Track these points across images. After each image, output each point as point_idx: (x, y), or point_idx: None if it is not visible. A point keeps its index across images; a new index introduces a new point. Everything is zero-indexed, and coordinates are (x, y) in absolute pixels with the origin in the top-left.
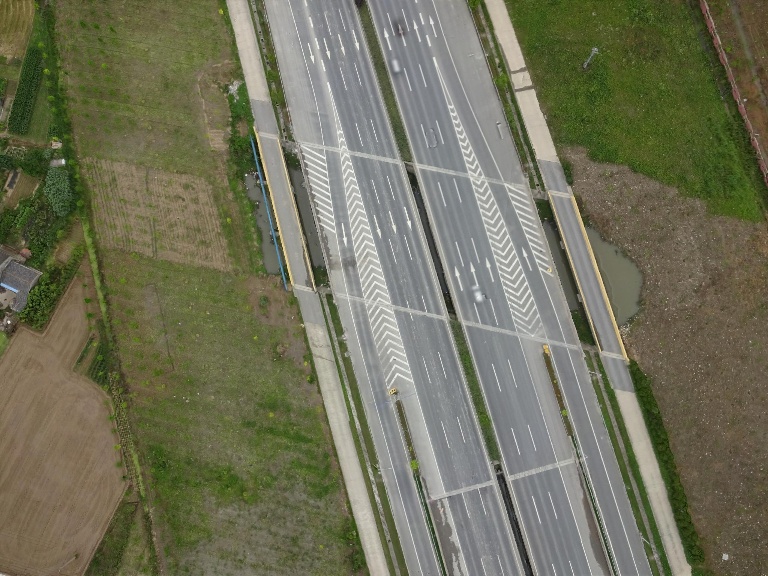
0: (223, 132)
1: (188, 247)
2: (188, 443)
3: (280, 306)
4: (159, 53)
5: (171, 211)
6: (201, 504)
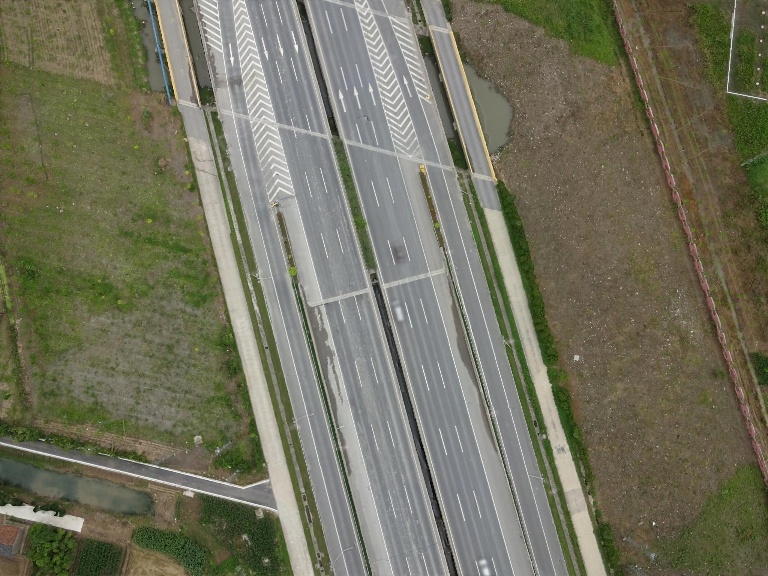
0: None
1: (68, 59)
2: (60, 253)
3: (163, 122)
4: None
5: (51, 22)
6: (72, 313)
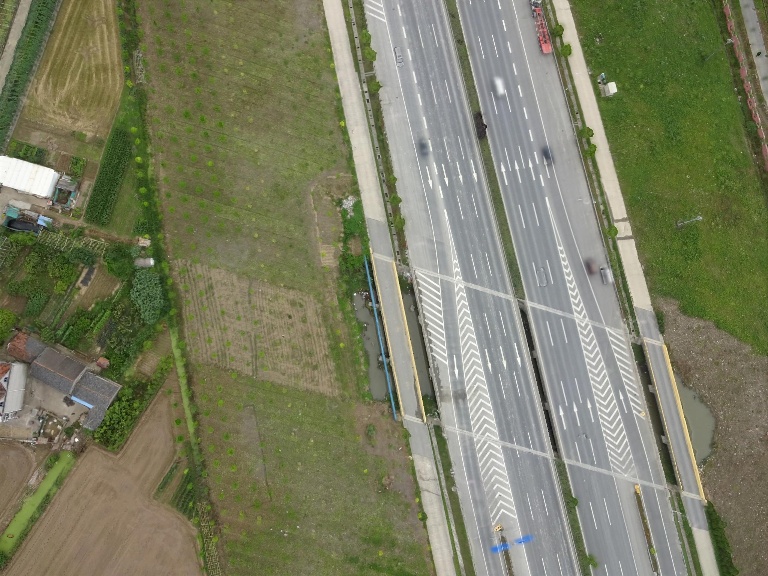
0: (334, 248)
1: (293, 368)
2: None
3: (387, 435)
4: (270, 156)
5: (276, 328)
6: None
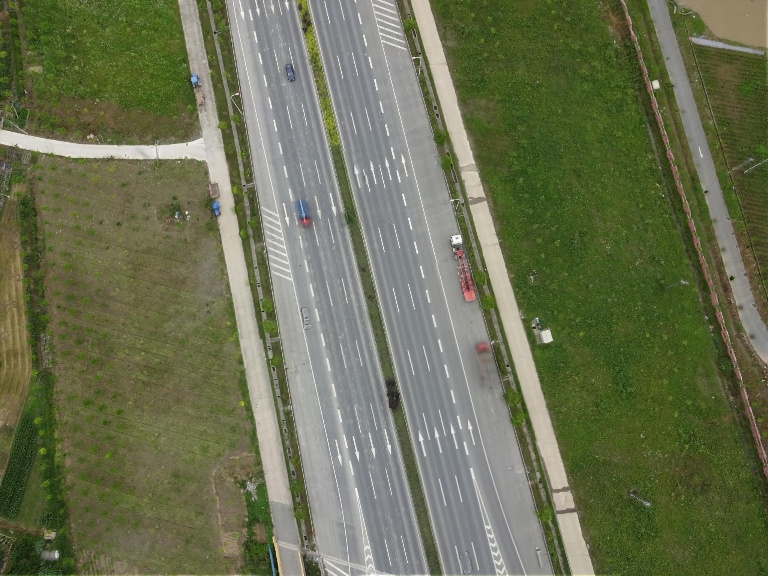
0: (238, 534)
1: None
2: None
3: None
4: (170, 440)
5: None
6: None
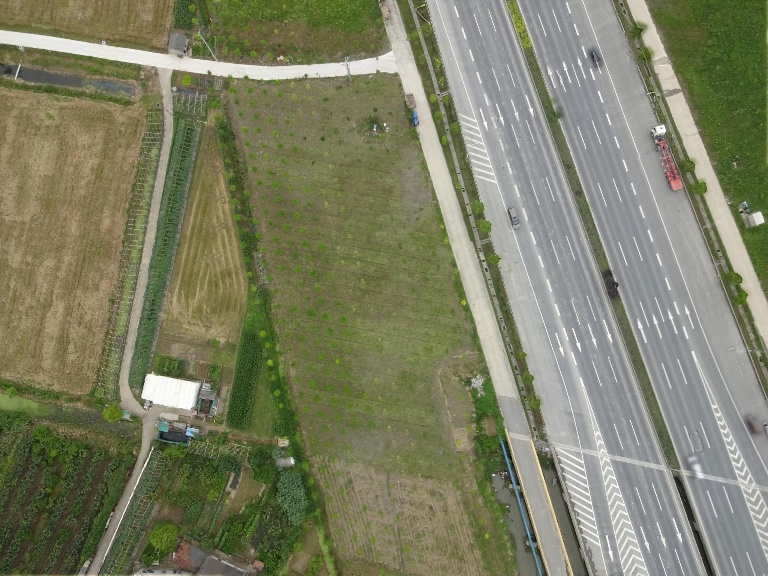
0: (467, 429)
1: (439, 560)
2: None
3: None
4: (394, 343)
5: (418, 520)
6: None
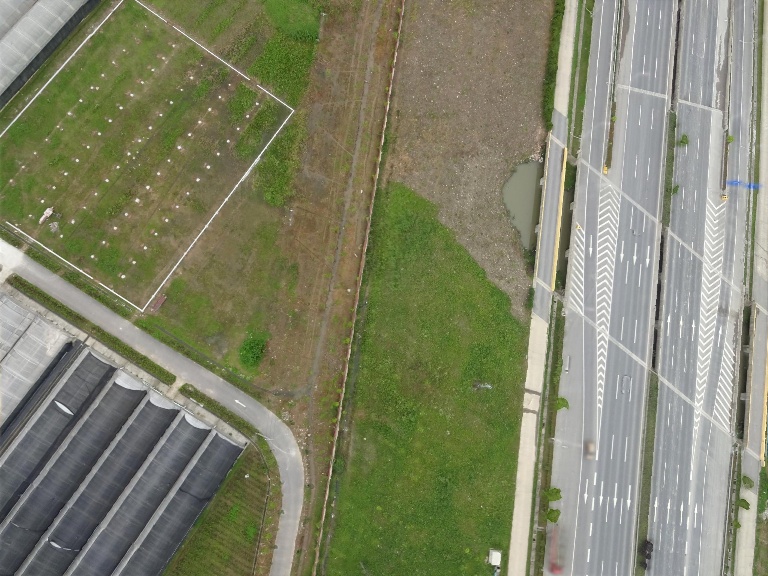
0: None
1: None
2: None
3: None
4: None
5: None
6: None
